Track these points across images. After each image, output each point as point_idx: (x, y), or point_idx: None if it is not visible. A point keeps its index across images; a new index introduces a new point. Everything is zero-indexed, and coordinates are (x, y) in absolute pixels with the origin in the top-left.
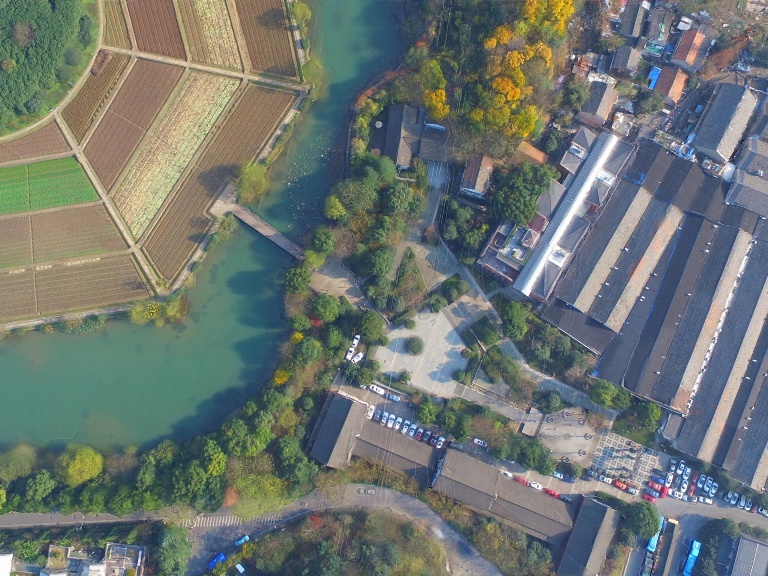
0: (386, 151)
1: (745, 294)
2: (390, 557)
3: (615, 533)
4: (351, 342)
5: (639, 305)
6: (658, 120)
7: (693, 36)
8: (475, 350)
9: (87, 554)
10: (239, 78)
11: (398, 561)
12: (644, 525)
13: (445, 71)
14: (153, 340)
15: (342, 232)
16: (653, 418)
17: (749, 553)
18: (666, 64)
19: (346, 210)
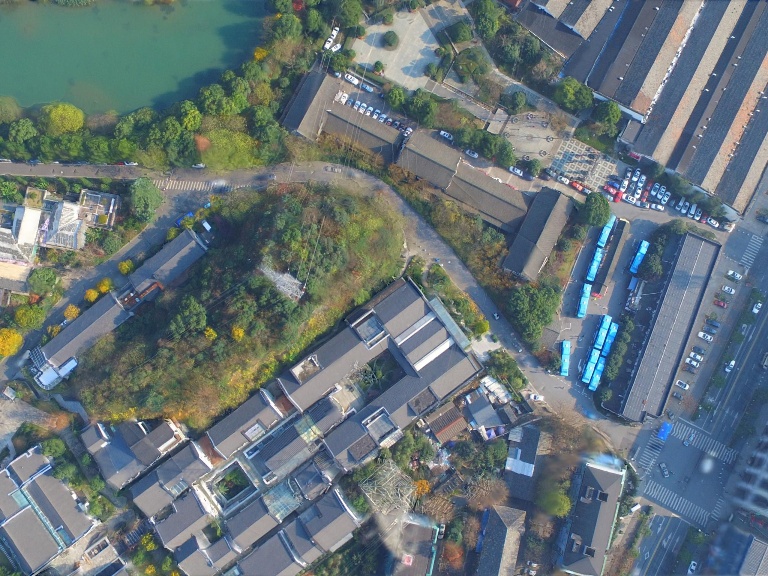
0: None
1: (711, 12)
2: (349, 204)
3: (568, 228)
4: (330, 31)
5: (608, 15)
6: None
7: None
8: (448, 49)
9: (62, 199)
10: None
11: (356, 209)
12: (595, 208)
13: None
14: (141, 19)
15: None
16: (612, 117)
17: (694, 249)
18: None
19: None
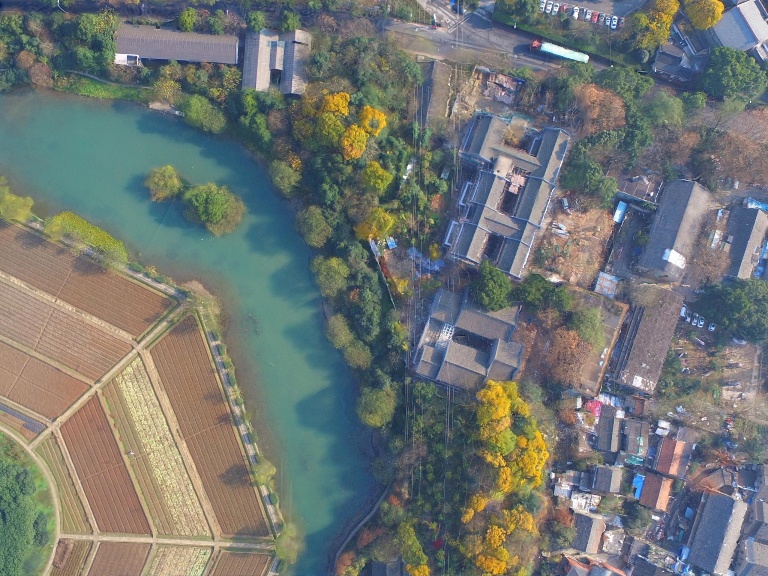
0: None
1: None
2: None
3: None
4: None
5: None
6: (648, 526)
7: (673, 446)
8: None
9: None
10: (210, 546)
11: None
12: None
13: (424, 533)
14: None
15: None
16: None
17: None
18: (649, 470)
19: None
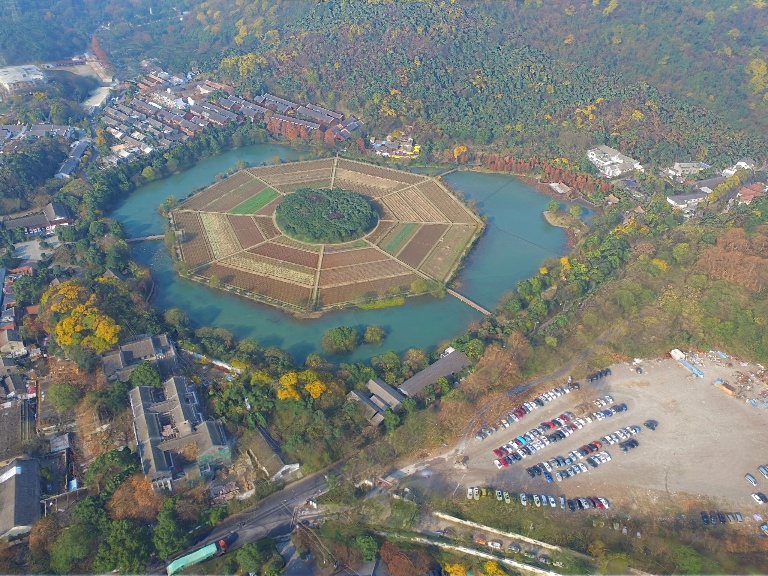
0: None
1: None
2: None
3: None
4: None
5: None
6: None
7: None
8: None
9: None
10: None
11: None
12: None
13: None
14: None
15: (111, 242)
16: None
17: None
18: None
19: None
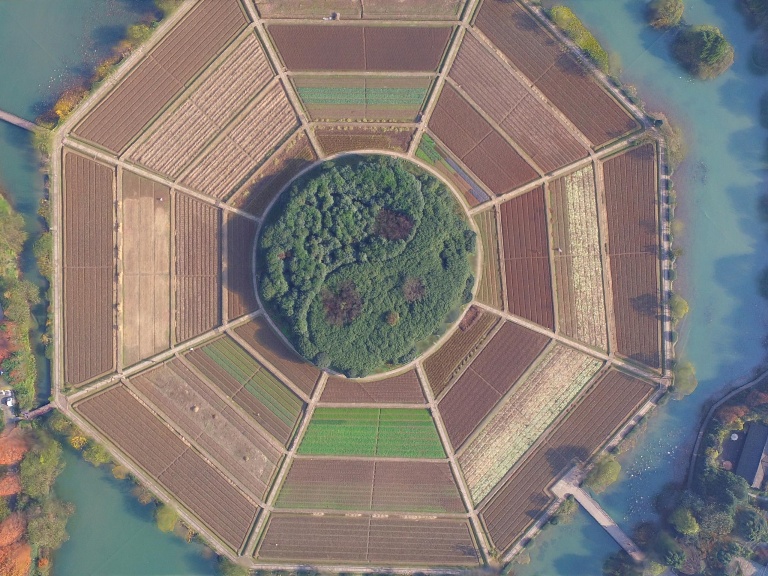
0: (740, 469)
1: None
2: None
3: None
4: None
5: None
6: None
7: None
8: None
9: None
10: (603, 359)
11: None
12: None
13: None
14: None
15: (690, 549)
16: None
17: None
18: None
19: (698, 528)
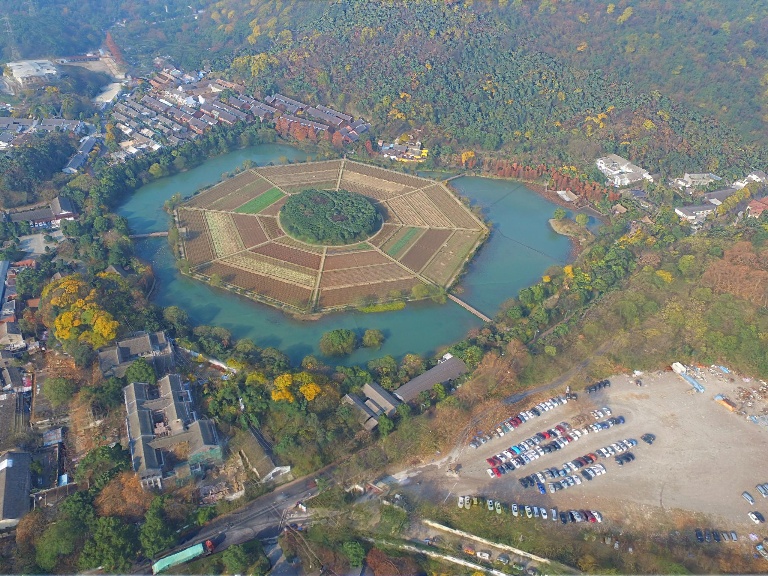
0: None
1: None
2: (7, 182)
3: None
4: None
5: None
6: None
7: None
8: None
9: None
10: None
11: (2, 183)
12: None
13: None
14: None
15: (115, 237)
16: None
17: None
18: None
19: None
